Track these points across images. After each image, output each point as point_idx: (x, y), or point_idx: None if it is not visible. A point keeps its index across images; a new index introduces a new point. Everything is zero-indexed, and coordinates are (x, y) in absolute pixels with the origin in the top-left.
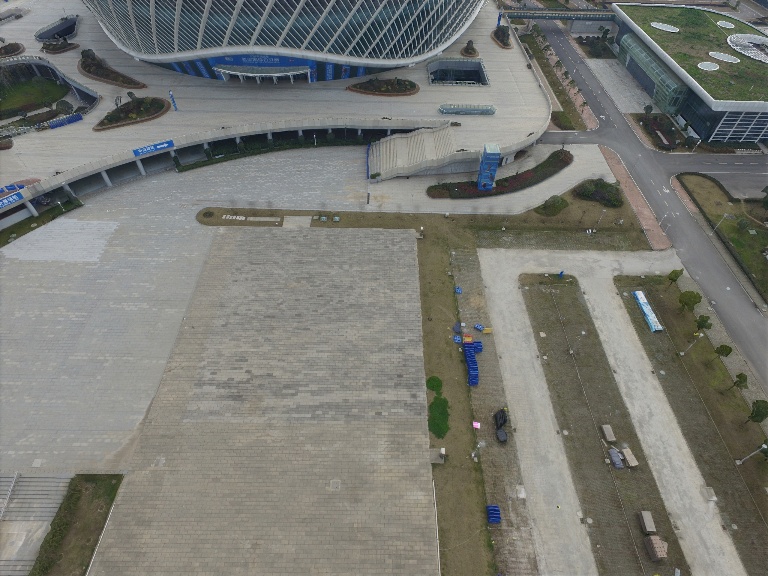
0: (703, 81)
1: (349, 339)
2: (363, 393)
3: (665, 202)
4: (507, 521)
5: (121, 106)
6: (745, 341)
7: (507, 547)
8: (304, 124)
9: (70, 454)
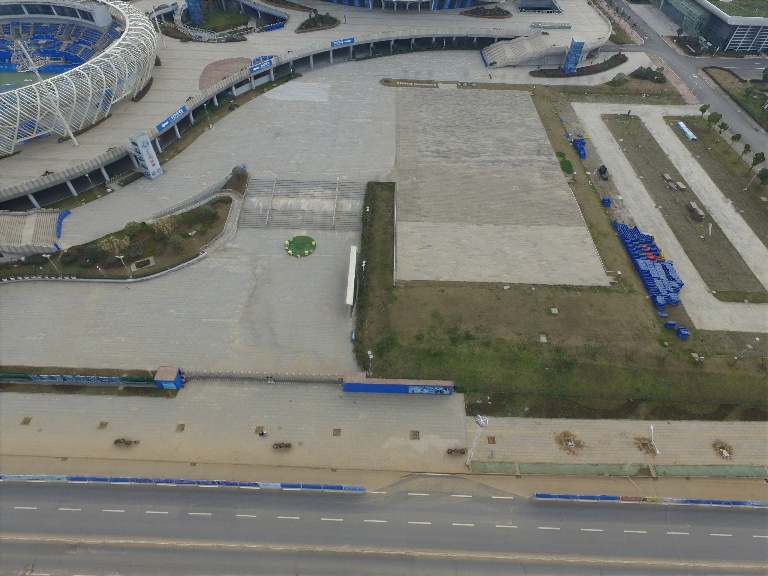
0: (721, 7)
1: (503, 136)
2: (519, 157)
3: (695, 82)
4: (614, 206)
5: (308, 19)
6: (749, 144)
7: (616, 214)
8: (438, 32)
9: (361, 175)
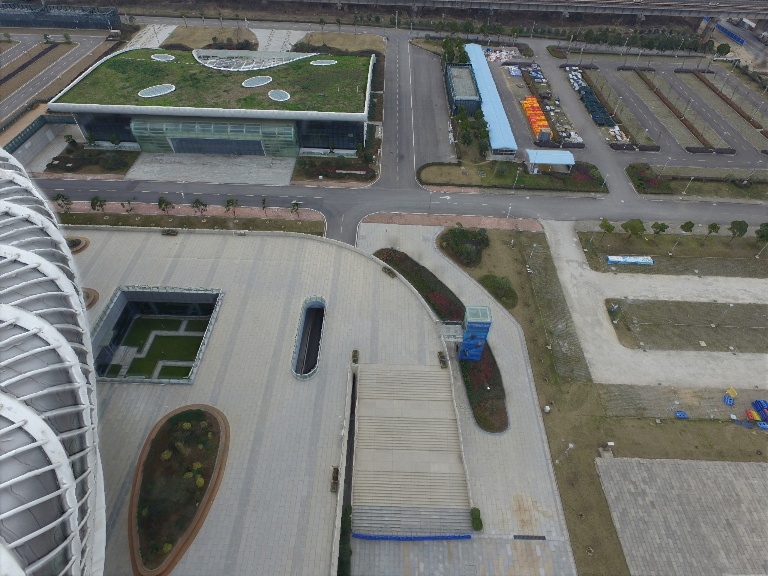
0: (315, 108)
1: None
2: None
3: (468, 204)
4: None
5: None
6: (638, 216)
7: None
8: None
9: None
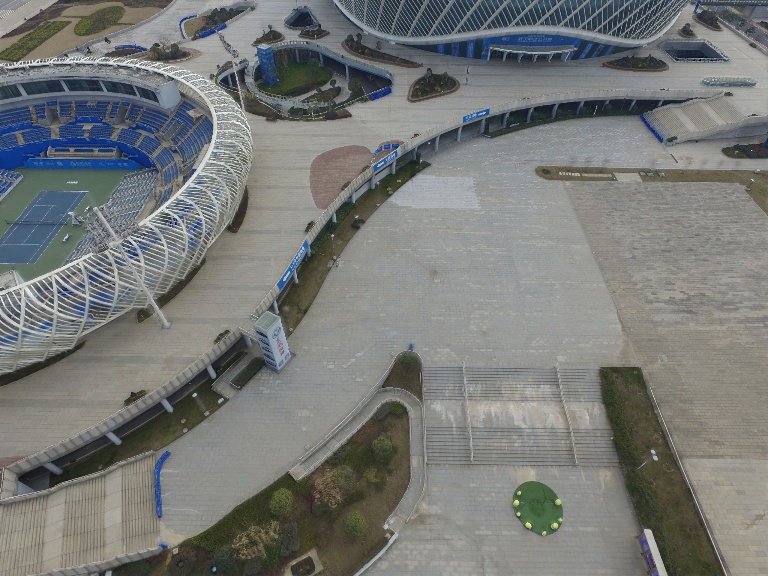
0: None
1: (750, 268)
2: None
3: None
4: None
5: (420, 81)
6: None
7: None
8: (590, 95)
9: (583, 352)
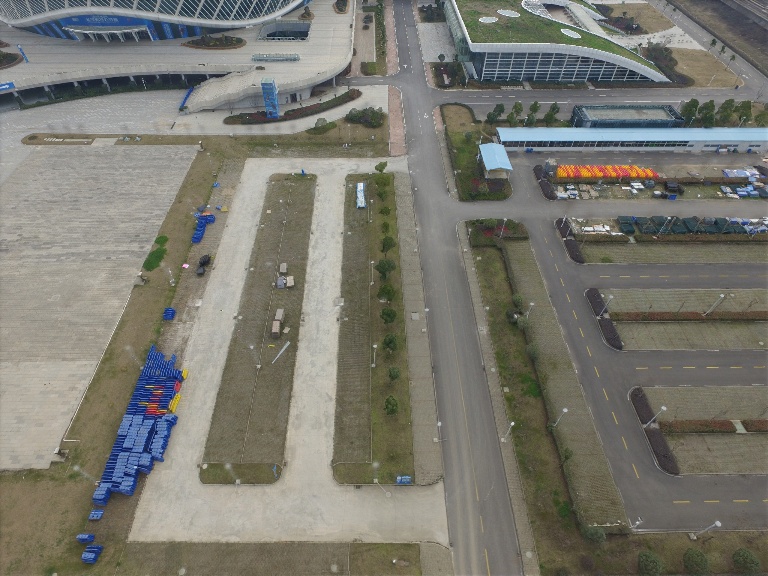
0: (474, 30)
1: (109, 214)
2: (103, 246)
3: (420, 124)
4: (179, 319)
5: None
6: (424, 212)
7: (171, 332)
8: (132, 70)
9: None
